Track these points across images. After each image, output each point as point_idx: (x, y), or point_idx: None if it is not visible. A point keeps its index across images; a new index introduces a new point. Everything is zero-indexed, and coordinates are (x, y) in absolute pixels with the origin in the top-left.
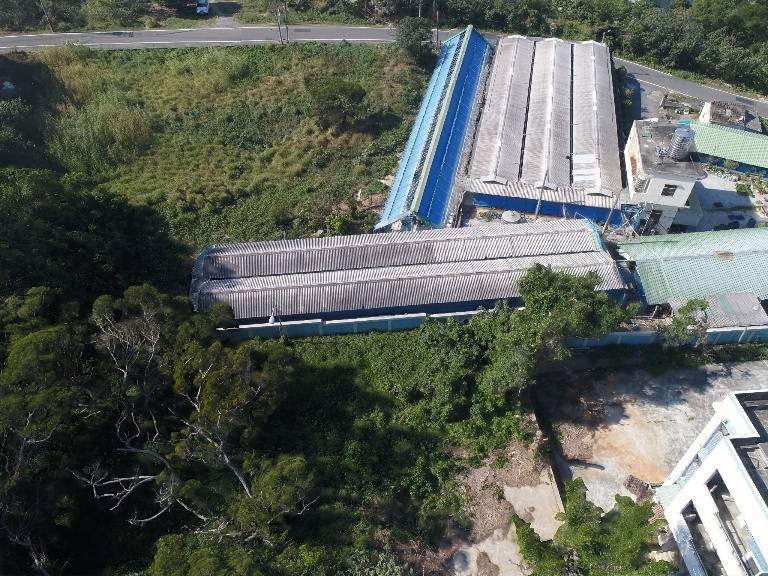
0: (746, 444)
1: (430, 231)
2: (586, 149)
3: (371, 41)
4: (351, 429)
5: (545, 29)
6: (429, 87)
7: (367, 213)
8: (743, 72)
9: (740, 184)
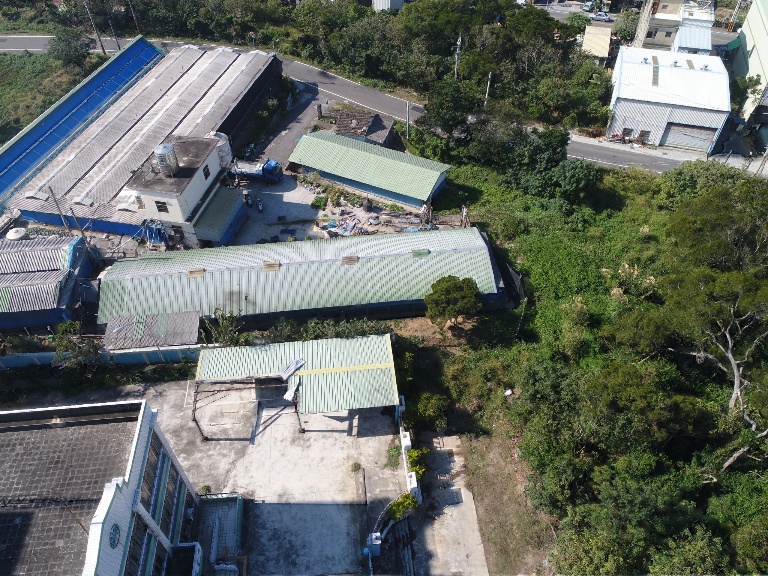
0: None
1: None
2: None
3: None
4: None
5: (250, 38)
6: None
7: None
8: (423, 81)
9: (320, 197)
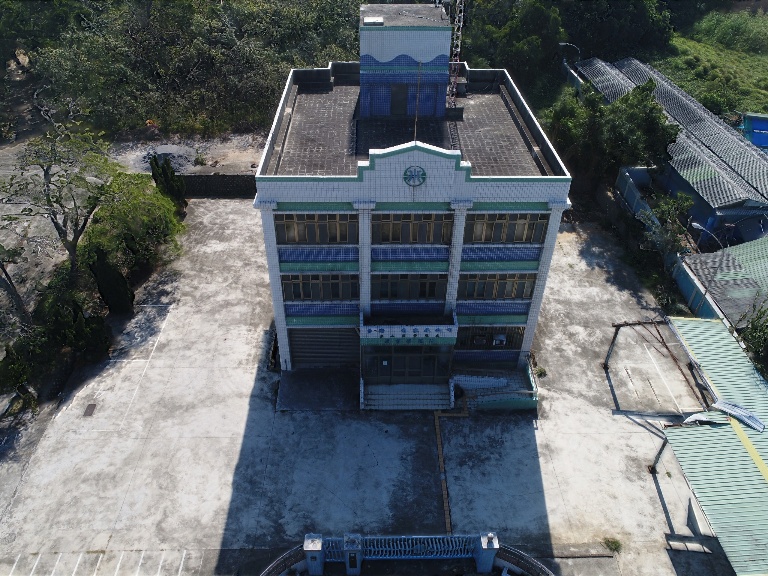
0: None
1: None
2: None
3: None
4: None
5: None
6: None
7: None
8: None
9: None
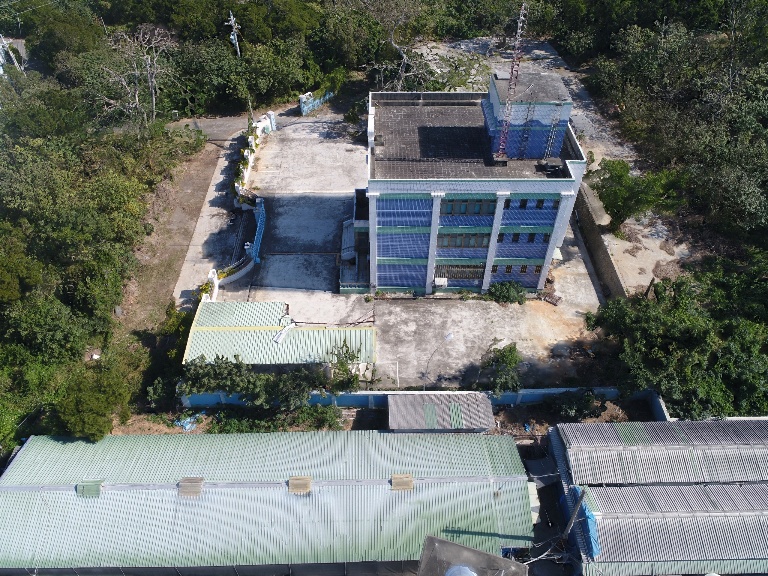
0: None
1: None
2: None
3: None
4: None
5: None
6: None
7: None
8: None
9: None
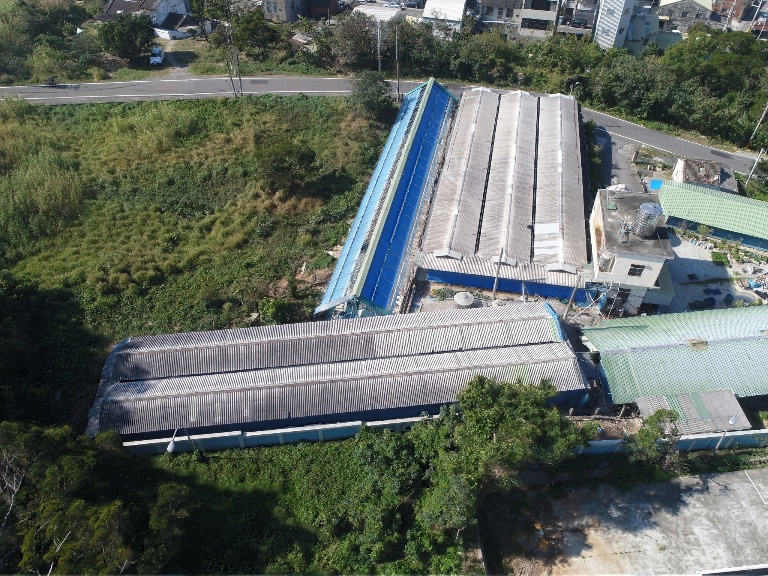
0: None
1: (373, 319)
2: (549, 217)
3: (330, 93)
4: None
5: (513, 79)
6: (386, 145)
7: (310, 291)
8: (718, 124)
9: (716, 252)
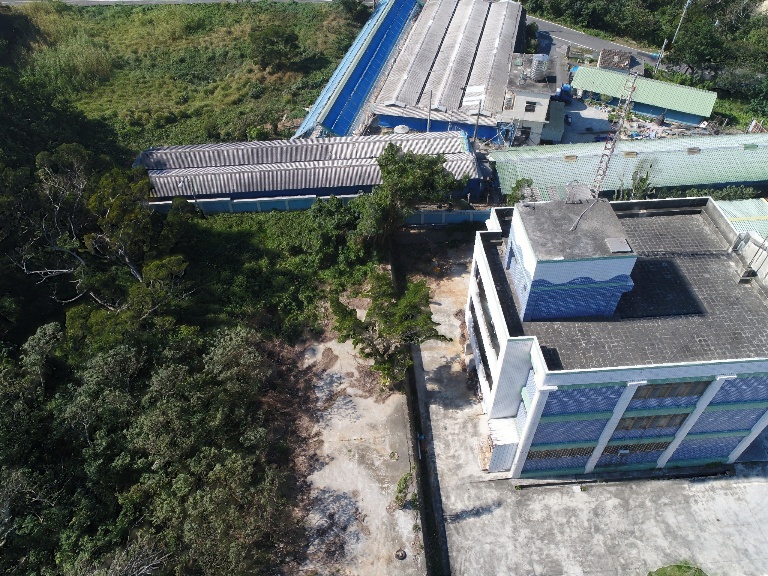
0: (495, 239)
1: (331, 138)
2: (479, 82)
3: (317, 1)
4: (241, 270)
5: None
6: (358, 36)
7: None
8: (645, 30)
9: (612, 114)
